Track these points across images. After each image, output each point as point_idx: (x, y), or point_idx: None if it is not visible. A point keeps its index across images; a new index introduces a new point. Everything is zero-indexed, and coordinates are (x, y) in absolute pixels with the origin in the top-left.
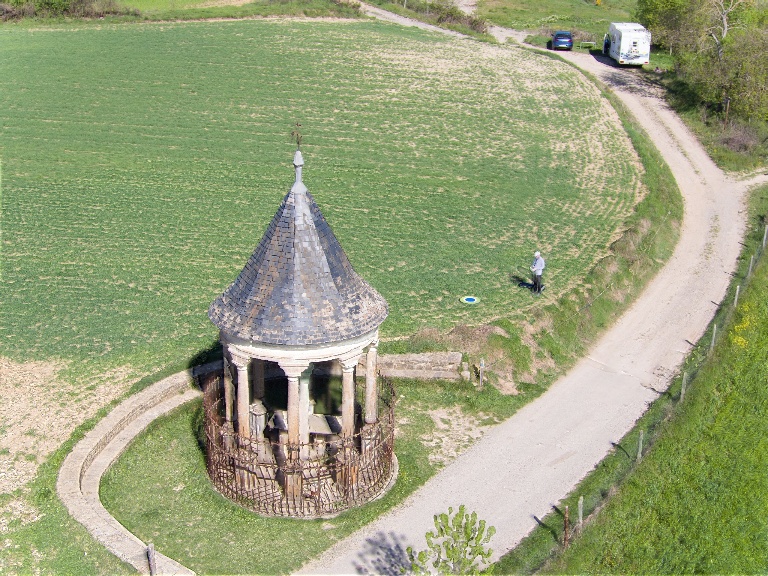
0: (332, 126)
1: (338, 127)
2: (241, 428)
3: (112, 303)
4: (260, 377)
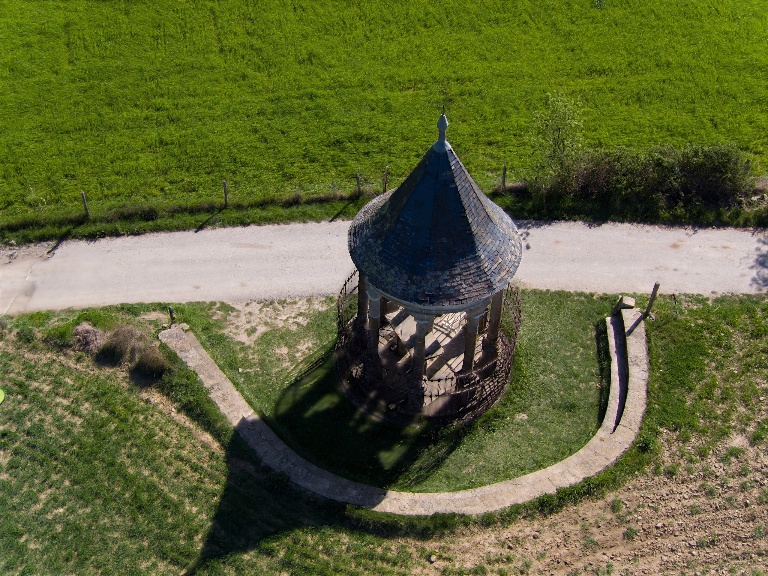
0: None
1: None
2: None
3: None
4: None
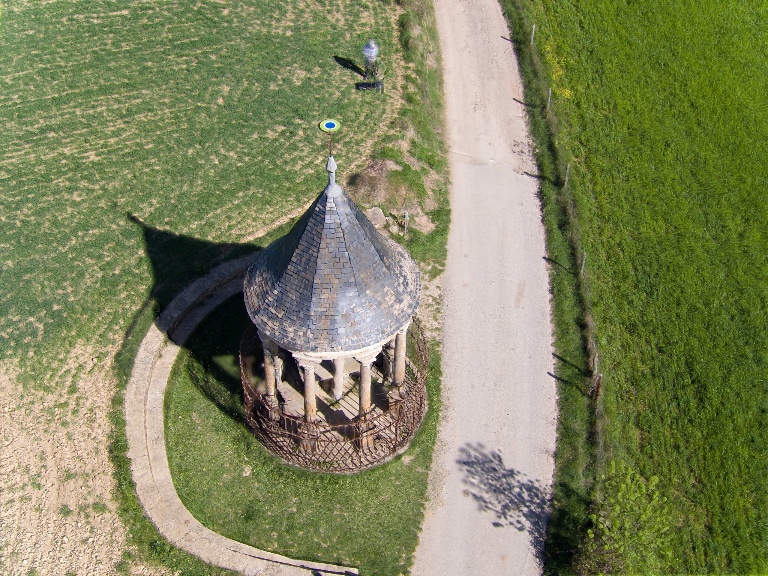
0: None
1: None
2: (310, 411)
3: None
4: None
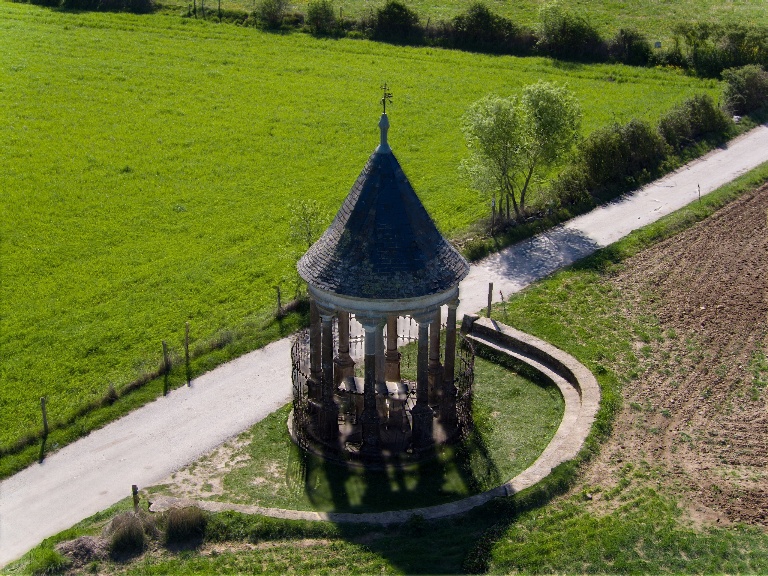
0: None
1: None
2: None
3: None
4: None
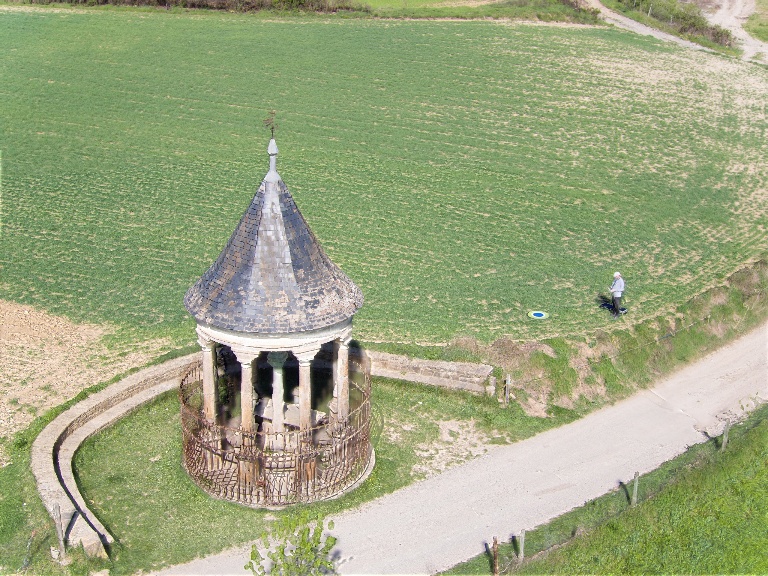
0: (502, 129)
1: (507, 131)
2: (205, 408)
3: (189, 279)
4: (252, 362)
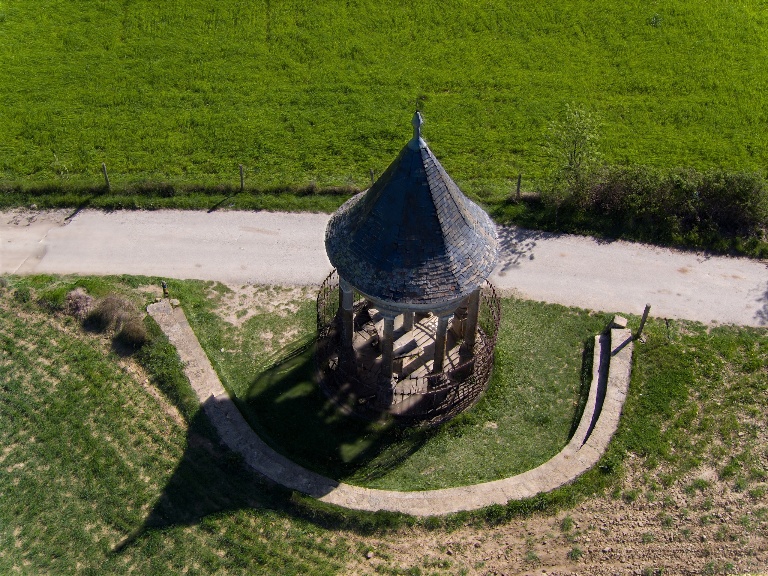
0: None
1: None
2: None
3: None
4: None
